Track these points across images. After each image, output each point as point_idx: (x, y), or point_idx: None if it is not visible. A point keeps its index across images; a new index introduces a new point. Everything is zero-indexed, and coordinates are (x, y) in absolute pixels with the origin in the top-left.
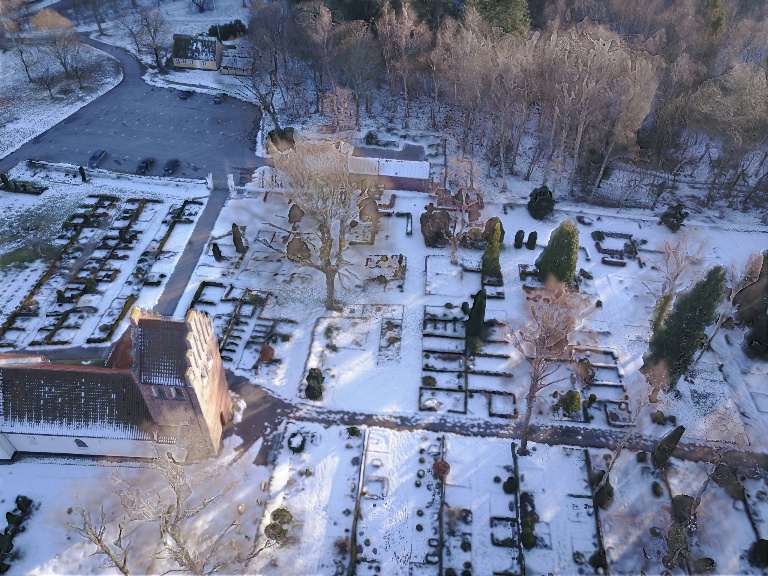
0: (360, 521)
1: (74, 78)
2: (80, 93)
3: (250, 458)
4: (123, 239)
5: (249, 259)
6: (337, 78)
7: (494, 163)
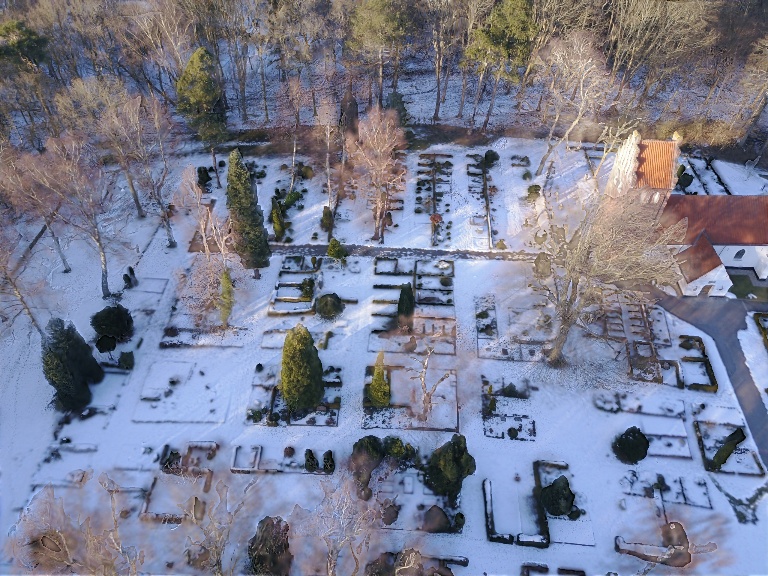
0: None
1: None
2: None
3: (569, 231)
4: None
5: (691, 445)
6: None
7: None
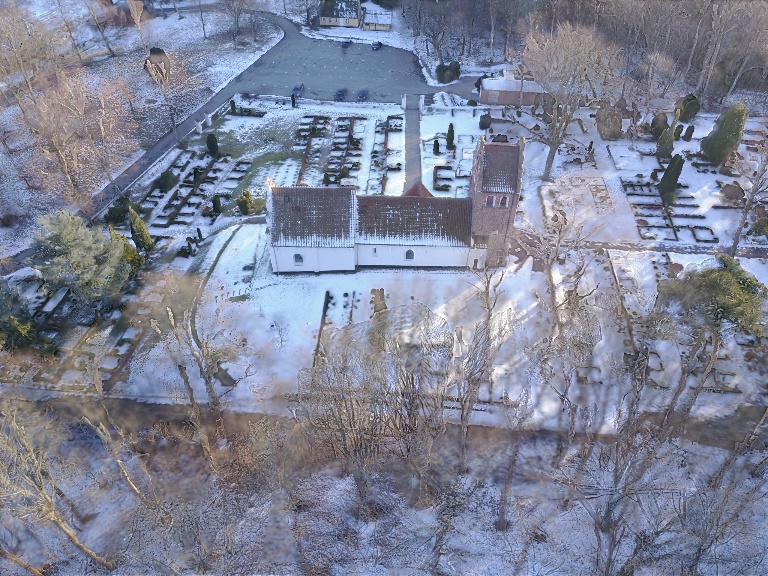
0: (625, 302)
1: (244, 34)
2: (256, 45)
3: (528, 268)
4: (352, 143)
5: (460, 153)
6: (466, 30)
7: (635, 84)
